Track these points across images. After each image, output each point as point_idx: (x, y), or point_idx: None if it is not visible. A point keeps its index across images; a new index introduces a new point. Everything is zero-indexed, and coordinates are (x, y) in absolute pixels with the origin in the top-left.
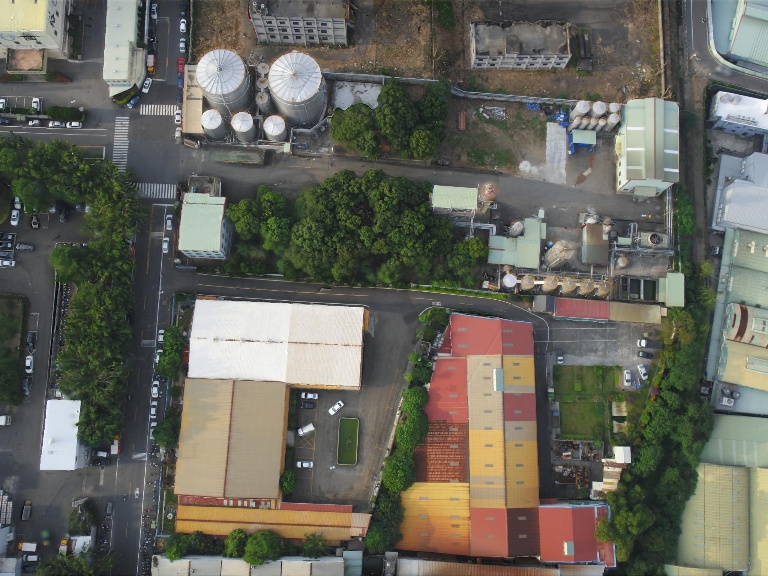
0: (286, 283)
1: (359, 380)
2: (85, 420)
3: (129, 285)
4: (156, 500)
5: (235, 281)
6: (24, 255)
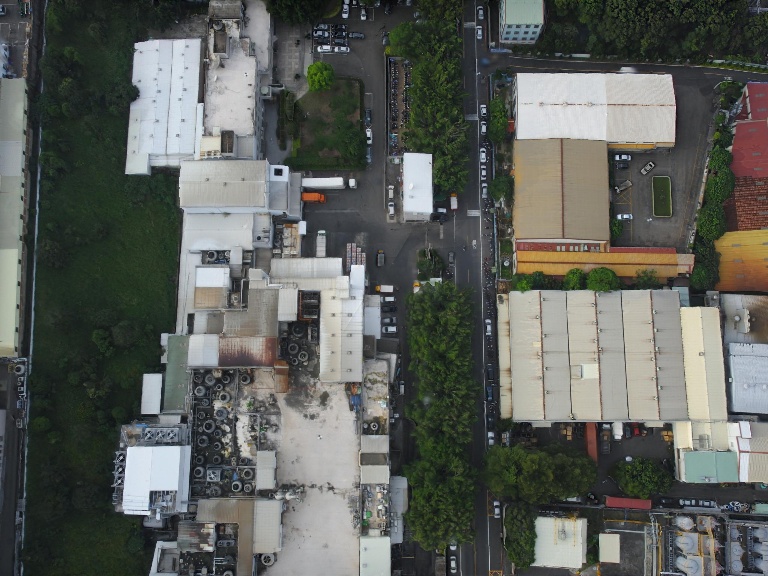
0: (589, 63)
1: (674, 136)
2: (442, 166)
3: (460, 59)
4: (493, 249)
5: (543, 63)
6: (356, 43)
